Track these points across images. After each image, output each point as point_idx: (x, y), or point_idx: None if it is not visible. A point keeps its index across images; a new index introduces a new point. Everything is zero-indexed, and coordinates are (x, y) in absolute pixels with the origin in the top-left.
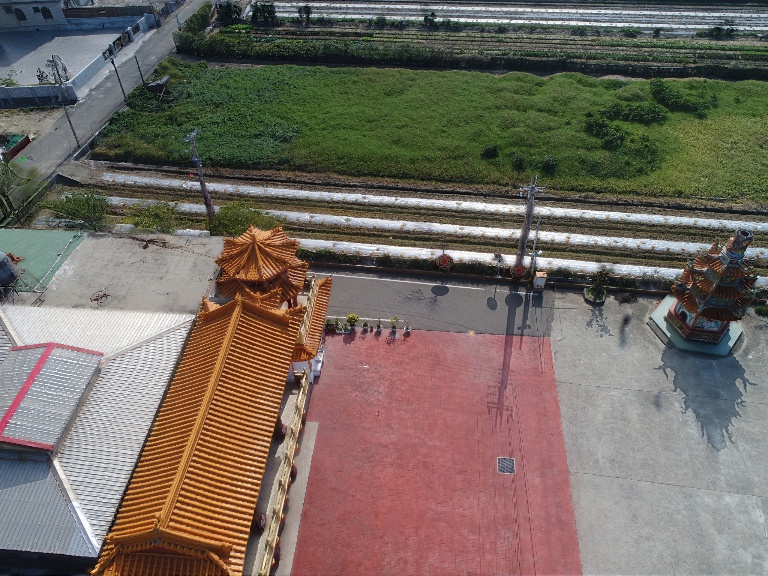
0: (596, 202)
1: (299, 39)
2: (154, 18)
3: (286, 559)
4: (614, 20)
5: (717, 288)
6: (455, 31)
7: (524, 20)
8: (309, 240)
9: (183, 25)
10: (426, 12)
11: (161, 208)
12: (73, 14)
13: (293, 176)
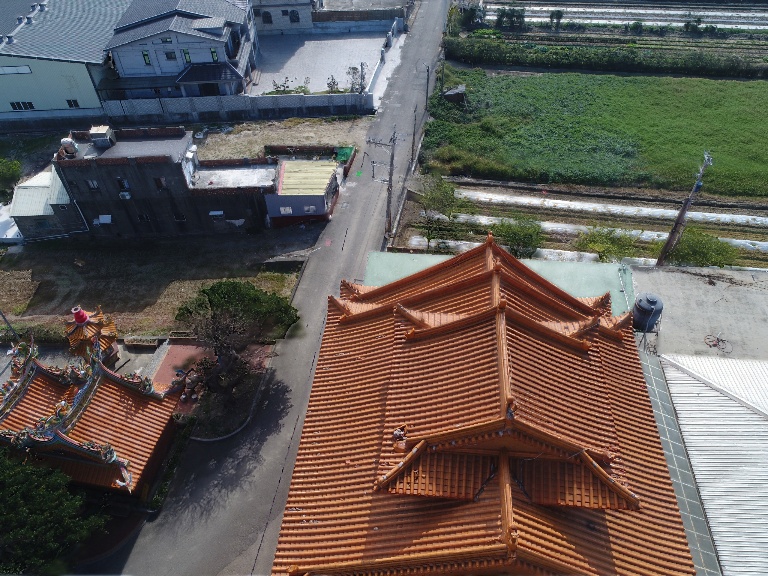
0: None
1: (559, 45)
2: (403, 22)
3: None
4: None
5: None
6: (721, 38)
7: None
8: (727, 266)
9: (448, 30)
10: (674, 17)
11: (622, 234)
12: (321, 17)
13: (660, 194)
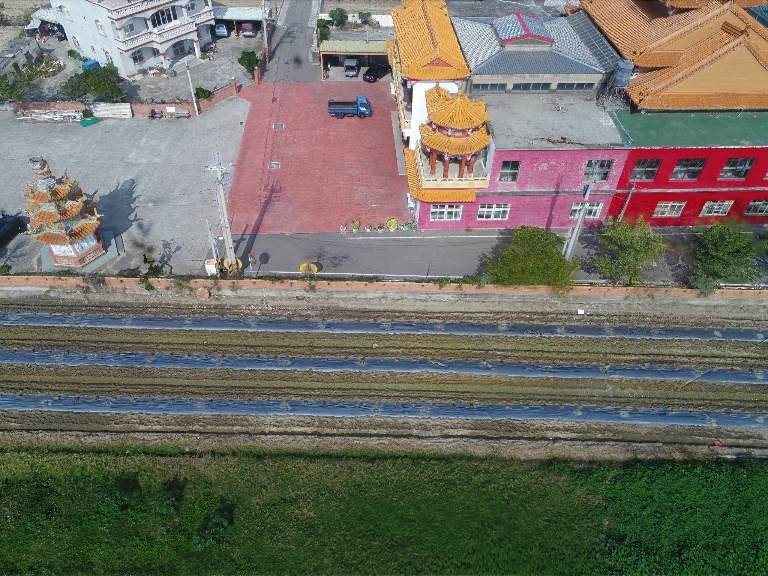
0: (76, 430)
1: None
2: None
3: (396, 127)
4: None
5: None
6: None
7: None
8: (473, 332)
9: None
10: None
11: (623, 237)
12: None
13: (552, 447)
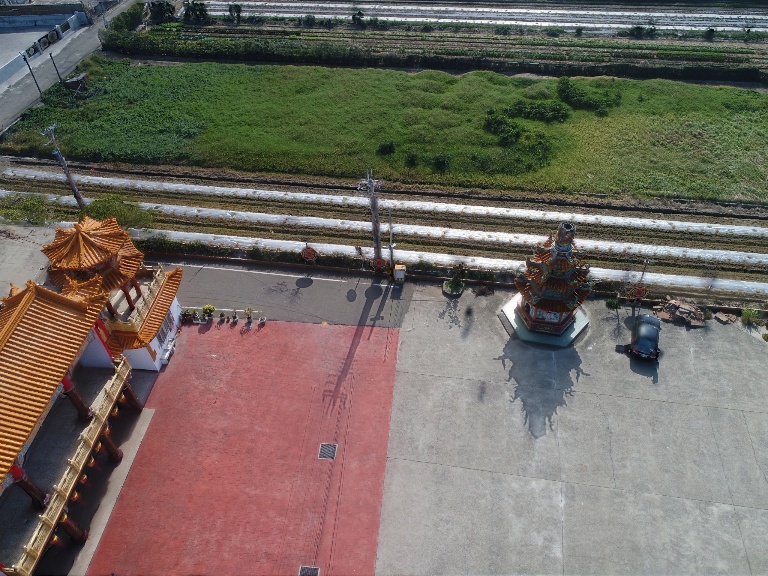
0: (480, 198)
1: (227, 37)
2: (85, 16)
3: (93, 539)
4: (541, 19)
5: (548, 280)
6: (382, 30)
7: (452, 19)
8: (192, 233)
9: (110, 23)
10: (358, 11)
11: (32, 201)
12: (5, 12)
13: (190, 171)
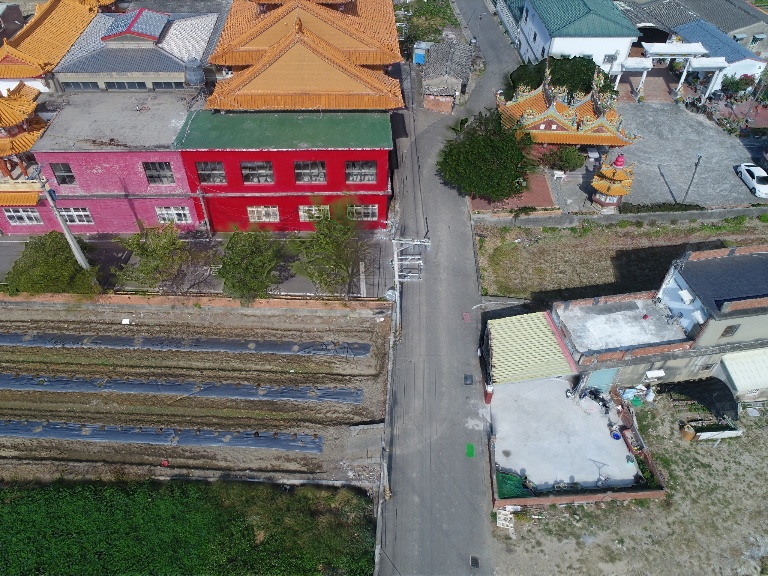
0: None
1: None
2: None
3: None
4: None
5: None
6: None
7: None
8: None
9: None
10: None
11: (135, 244)
12: None
13: None
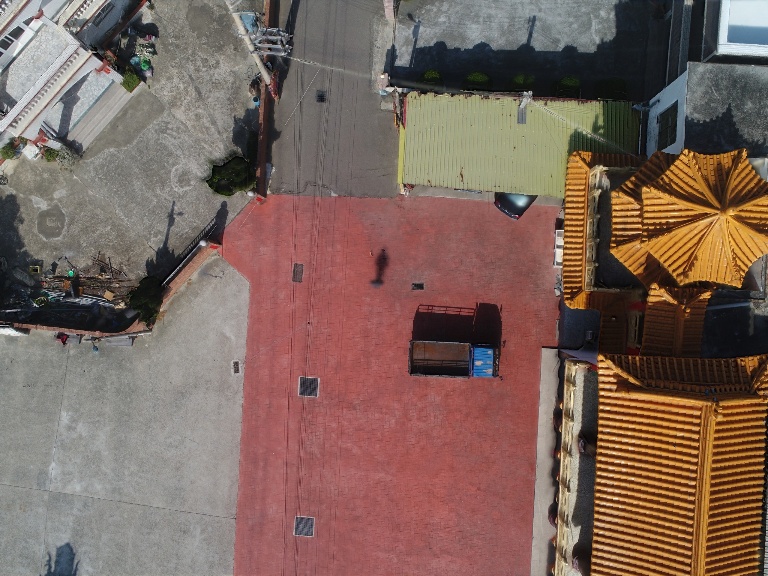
0: None
1: None
2: None
3: (546, 419)
4: None
5: None
6: None
7: None
8: None
9: None
10: None
11: None
12: None
13: None
